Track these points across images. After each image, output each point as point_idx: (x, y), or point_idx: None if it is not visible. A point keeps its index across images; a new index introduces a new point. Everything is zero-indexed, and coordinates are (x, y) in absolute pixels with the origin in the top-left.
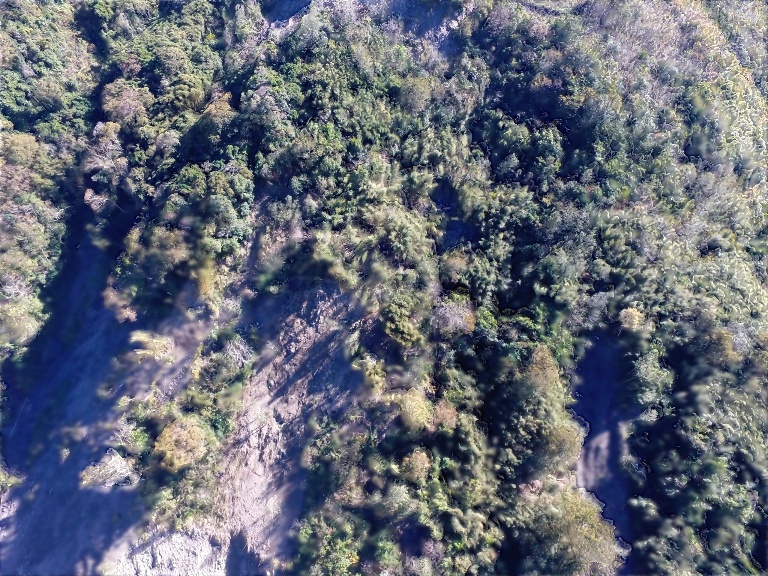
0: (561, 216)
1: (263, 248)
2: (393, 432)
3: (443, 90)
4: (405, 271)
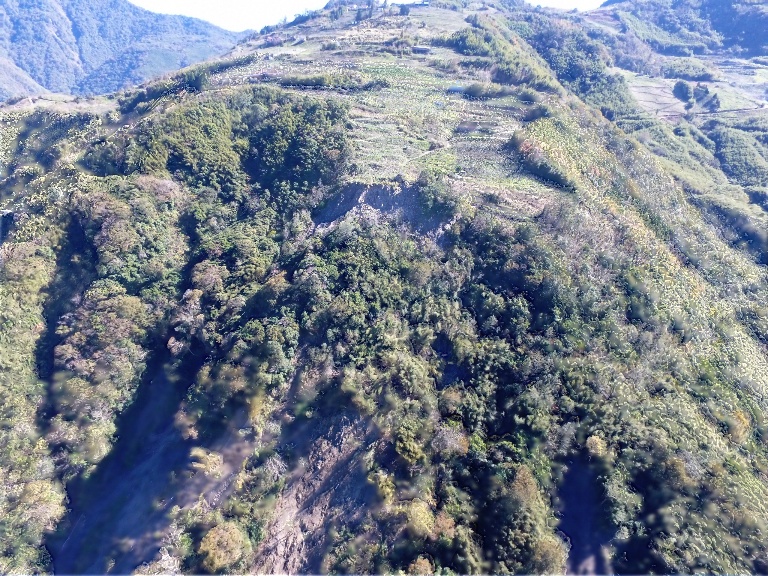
0: (531, 361)
1: (302, 382)
2: (401, 543)
3: (440, 270)
4: (411, 401)
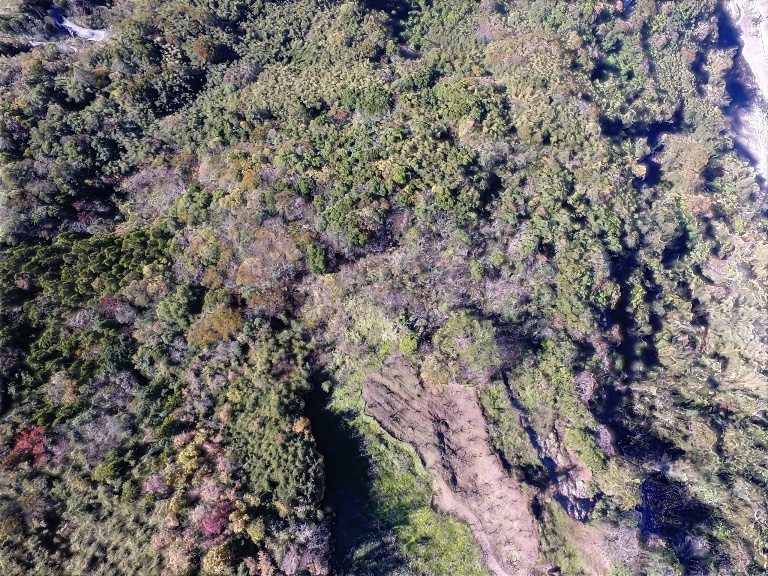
0: None
1: None
2: None
3: None
4: None
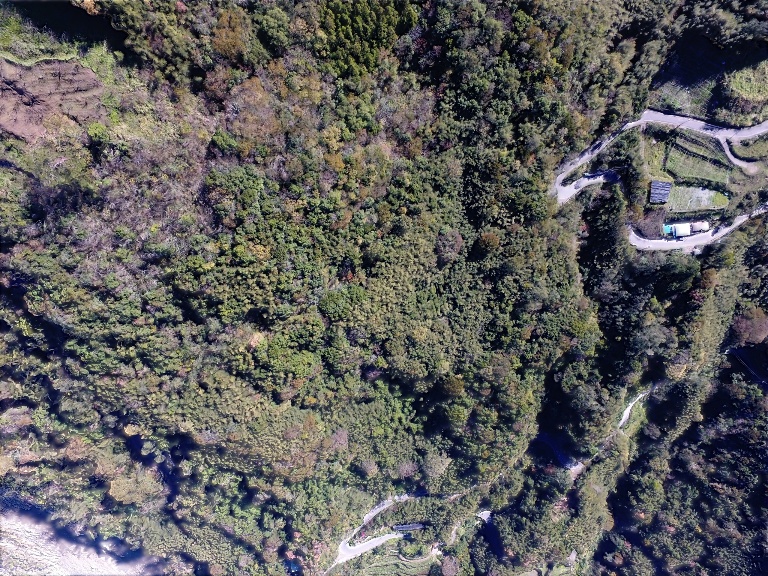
0: None
1: None
2: None
3: None
4: None
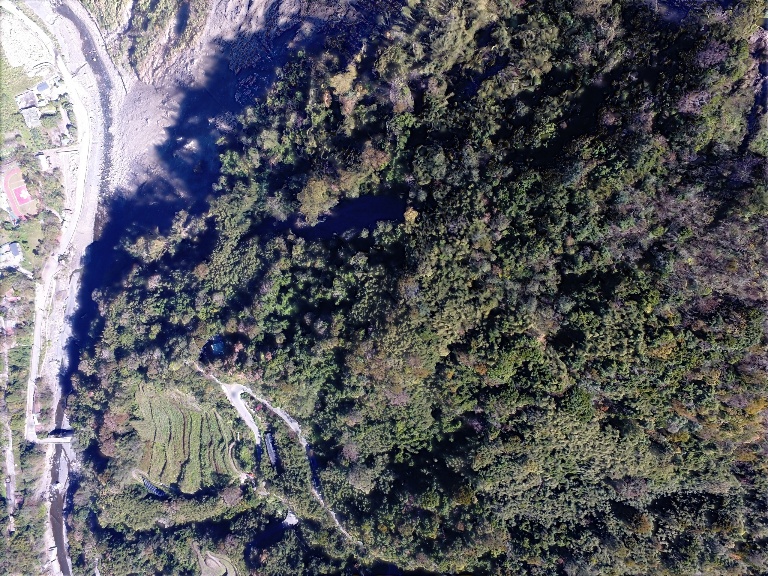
0: None
1: None
2: None
3: None
4: None
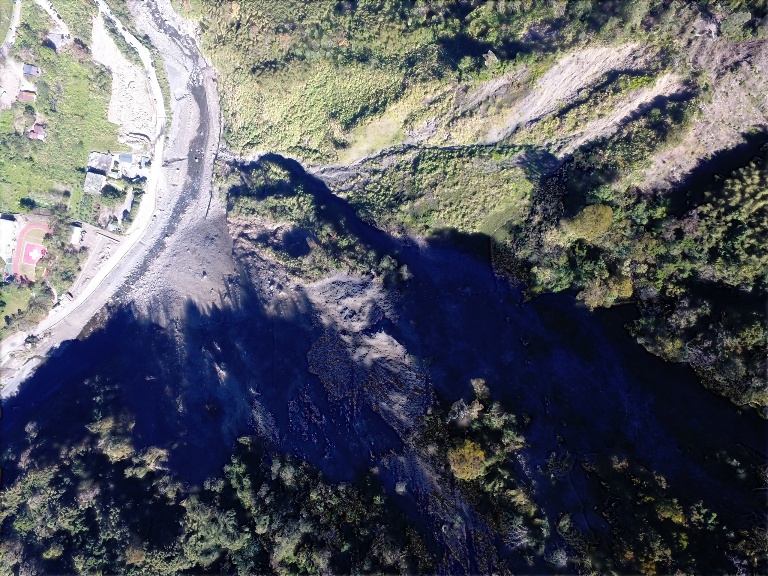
0: None
1: None
2: None
3: None
4: None
